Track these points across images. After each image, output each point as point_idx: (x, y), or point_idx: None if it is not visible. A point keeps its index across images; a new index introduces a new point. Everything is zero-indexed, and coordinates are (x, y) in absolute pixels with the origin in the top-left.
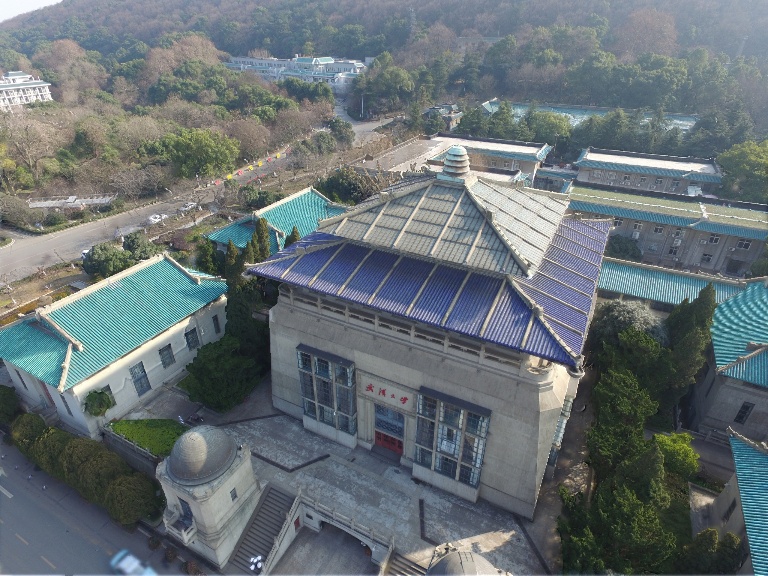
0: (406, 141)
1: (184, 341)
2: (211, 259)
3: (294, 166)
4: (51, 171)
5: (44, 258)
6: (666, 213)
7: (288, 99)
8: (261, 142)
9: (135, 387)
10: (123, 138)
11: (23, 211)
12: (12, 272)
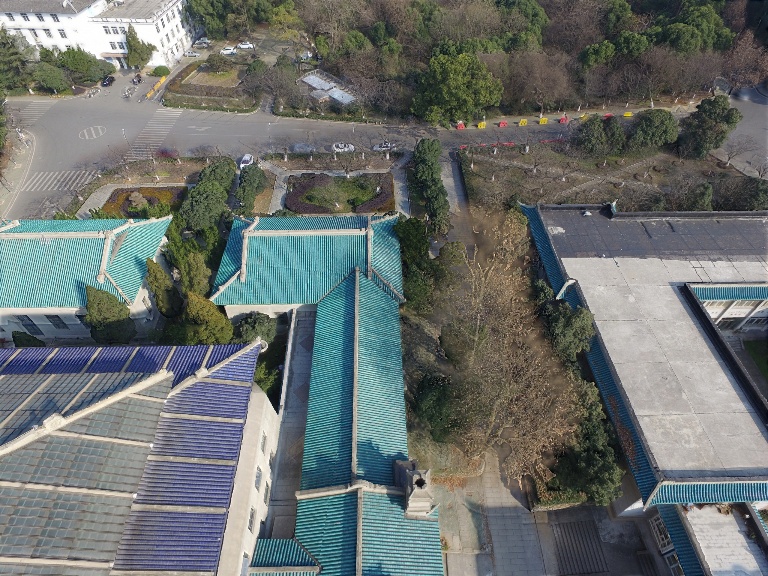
0: (753, 211)
1: (77, 319)
2: (212, 247)
3: (570, 148)
4: (346, 47)
5: (237, 142)
6: None
7: (691, 29)
8: (565, 91)
9: (26, 328)
10: (440, 26)
11: (279, 85)
12: (199, 147)
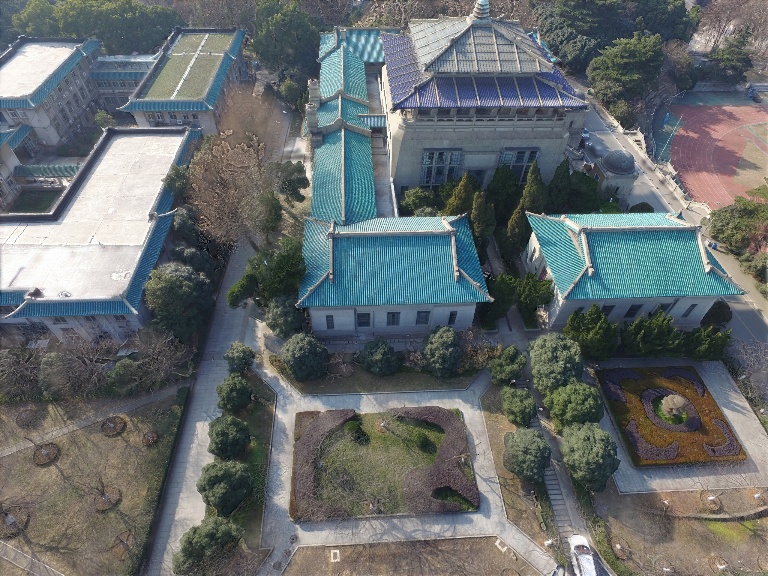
0: None
1: None
2: None
3: None
4: None
5: None
6: (220, 61)
7: None
8: None
9: None
10: None
11: None
12: None
